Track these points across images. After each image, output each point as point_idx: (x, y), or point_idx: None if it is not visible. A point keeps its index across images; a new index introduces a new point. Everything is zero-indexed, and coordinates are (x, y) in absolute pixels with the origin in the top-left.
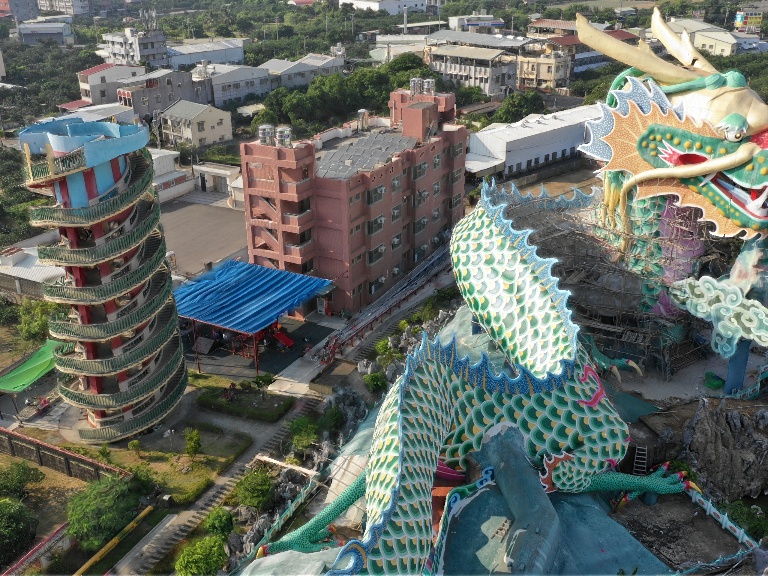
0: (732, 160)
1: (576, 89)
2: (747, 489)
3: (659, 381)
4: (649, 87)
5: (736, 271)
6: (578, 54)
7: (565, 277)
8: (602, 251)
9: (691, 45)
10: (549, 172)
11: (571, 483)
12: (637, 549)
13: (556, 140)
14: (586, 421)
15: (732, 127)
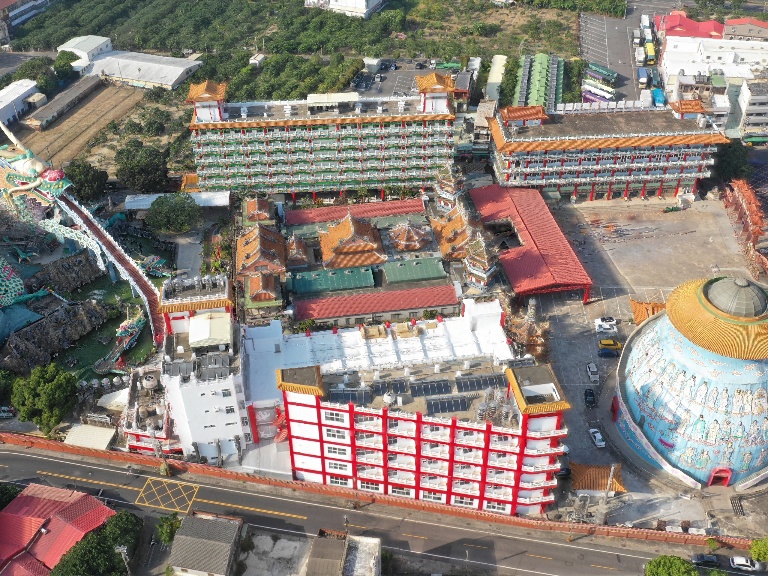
0: (36, 184)
1: (15, 47)
2: (76, 285)
3: (48, 256)
4: (2, 160)
5: (55, 215)
6: (11, 12)
7: (0, 228)
8: (11, 215)
9: (15, 138)
10: (2, 139)
11: (7, 303)
12: (32, 314)
13: (1, 116)
14: (7, 284)
15: (32, 174)
